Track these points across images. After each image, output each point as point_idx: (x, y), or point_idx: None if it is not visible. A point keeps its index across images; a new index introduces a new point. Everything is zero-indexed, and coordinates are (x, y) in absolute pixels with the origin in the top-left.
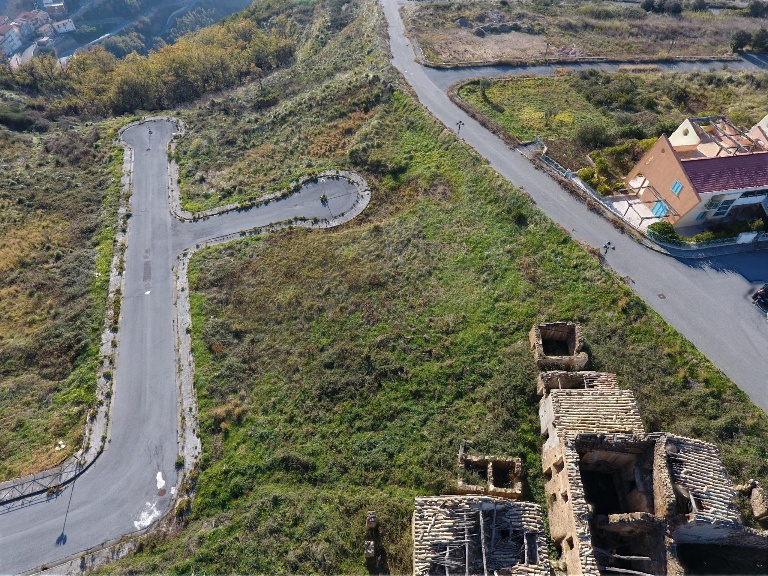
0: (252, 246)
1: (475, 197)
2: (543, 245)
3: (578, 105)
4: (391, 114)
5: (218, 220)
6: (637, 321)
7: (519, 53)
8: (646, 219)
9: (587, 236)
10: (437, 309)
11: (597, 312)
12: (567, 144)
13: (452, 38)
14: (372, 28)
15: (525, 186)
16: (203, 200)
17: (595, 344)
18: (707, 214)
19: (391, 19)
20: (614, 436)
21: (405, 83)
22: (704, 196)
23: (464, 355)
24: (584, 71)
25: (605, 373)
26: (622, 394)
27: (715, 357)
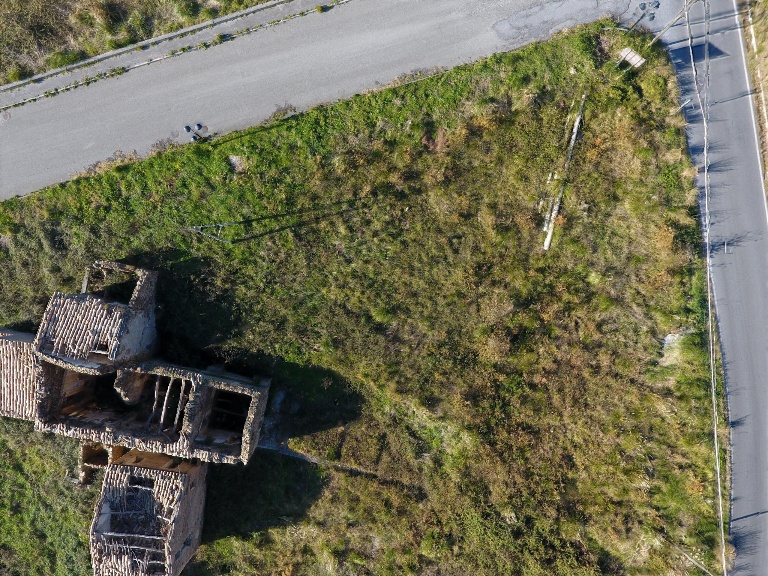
0: None
1: None
2: None
3: None
4: None
5: None
6: None
7: None
8: None
9: None
10: None
11: None
12: None
13: None
14: None
15: None
16: None
17: None
18: None
19: None
20: None
21: None
22: None
23: None
24: None
25: None
26: None
27: None
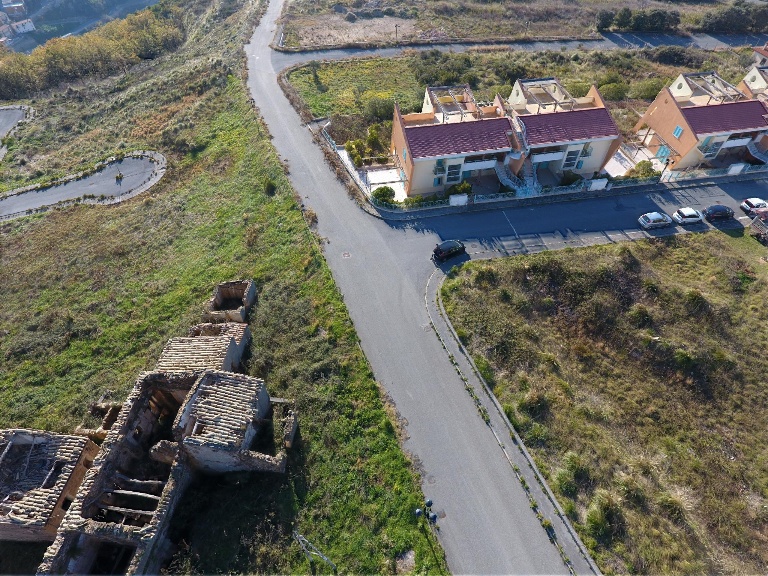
0: (31, 223)
1: (245, 171)
2: (275, 212)
3: (404, 84)
4: (220, 96)
5: (14, 200)
6: (310, 278)
7: (382, 37)
8: (373, 185)
9: (316, 202)
10: (158, 274)
11: (286, 271)
12: (356, 119)
13: (321, 23)
14: (247, 16)
15: (290, 159)
16: (12, 182)
17: (264, 300)
18: (443, 180)
19: (272, 7)
20: (171, 374)
21: (244, 66)
22: (421, 161)
23: (155, 315)
24: (425, 51)
25: (239, 323)
26: (222, 339)
27: (355, 307)
